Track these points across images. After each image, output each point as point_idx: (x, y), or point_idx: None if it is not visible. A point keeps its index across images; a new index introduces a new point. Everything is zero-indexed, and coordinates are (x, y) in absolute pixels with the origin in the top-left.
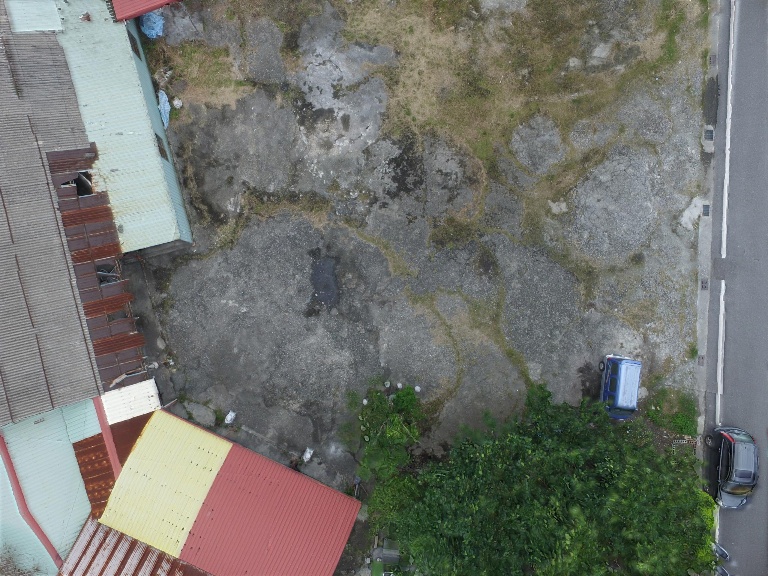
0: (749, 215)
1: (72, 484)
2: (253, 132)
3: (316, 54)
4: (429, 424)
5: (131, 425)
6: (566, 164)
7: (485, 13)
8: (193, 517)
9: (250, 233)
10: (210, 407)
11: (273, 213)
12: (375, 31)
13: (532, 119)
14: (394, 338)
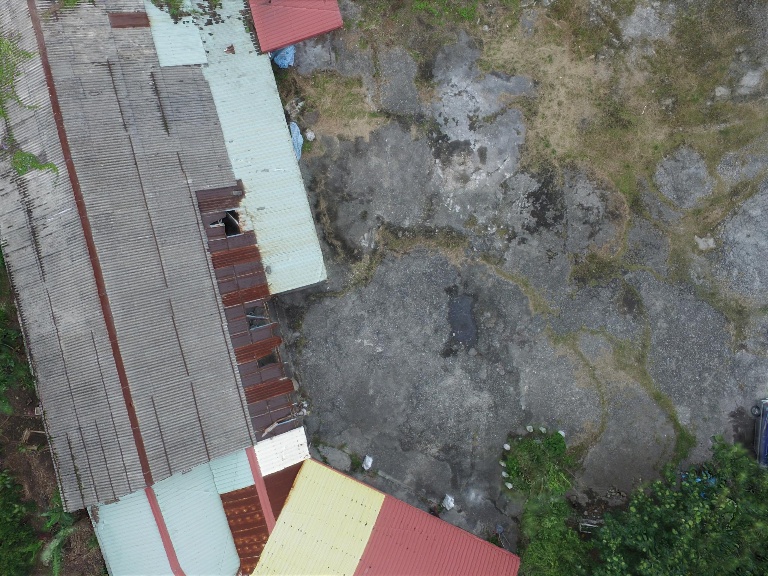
0: None
1: (220, 537)
2: (387, 165)
3: (451, 84)
4: (573, 470)
5: (284, 476)
6: (713, 198)
7: (626, 41)
8: (350, 574)
9: (385, 270)
10: (345, 451)
11: (408, 249)
12: (512, 60)
13: (677, 151)
14: (535, 380)
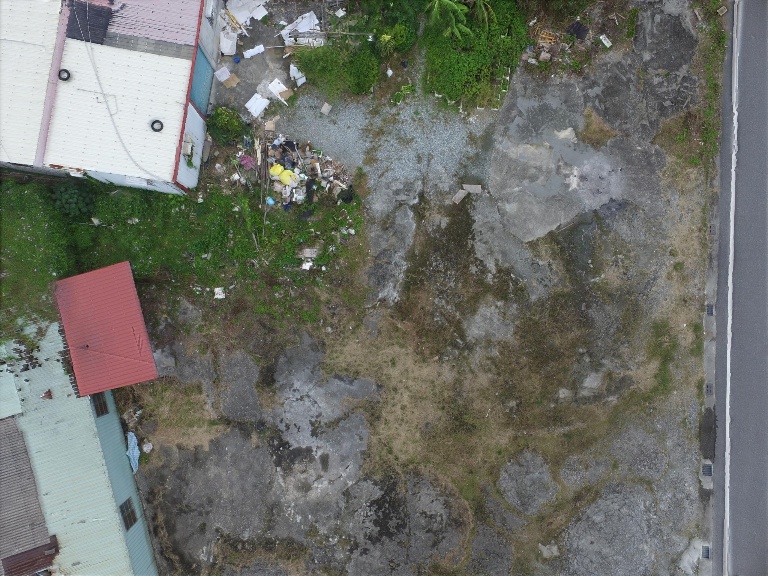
0: (751, 558)
1: None
2: (227, 474)
3: (293, 389)
4: None
5: None
6: (557, 504)
7: (470, 342)
8: None
9: None
10: None
11: (248, 562)
12: (355, 363)
13: (521, 455)
14: None
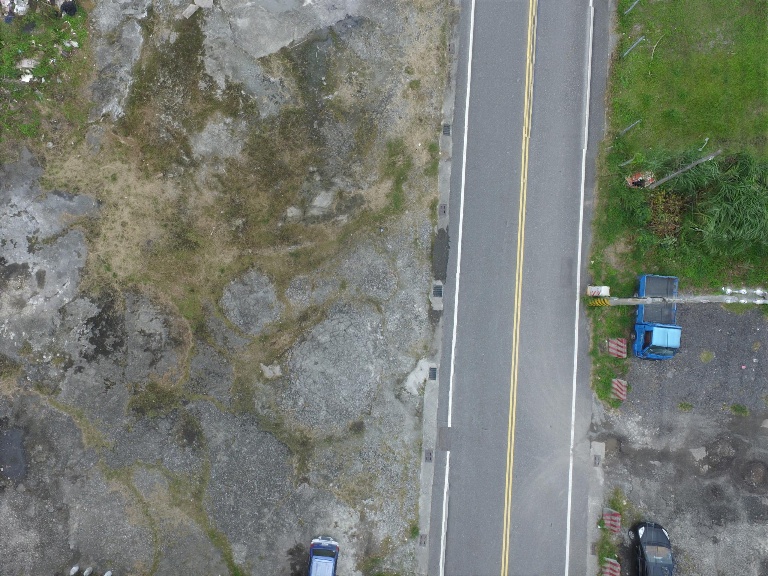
0: (478, 380)
1: None
2: None
3: (11, 204)
4: None
5: None
6: (281, 324)
7: (197, 159)
8: None
9: None
10: None
11: None
12: (76, 179)
13: (245, 274)
14: (86, 517)
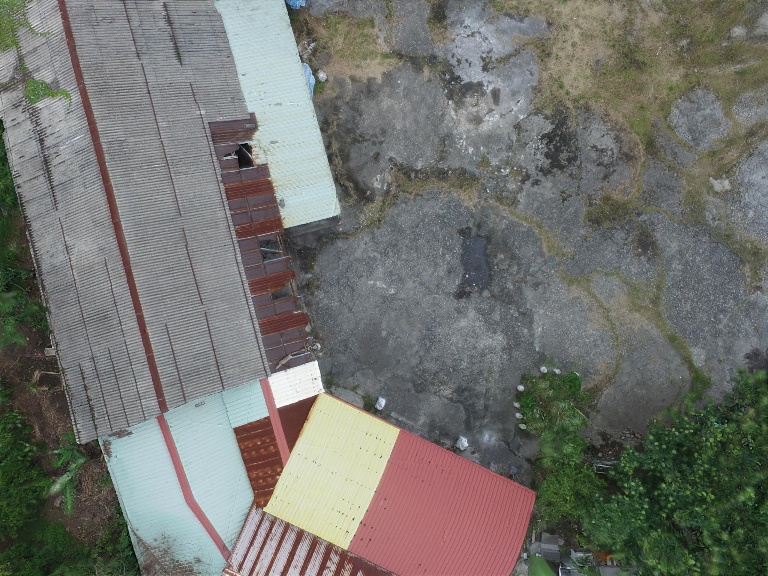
0: None
1: (234, 471)
2: (400, 106)
3: (464, 25)
4: (587, 412)
5: (298, 409)
6: (728, 139)
7: None
8: (365, 506)
9: (397, 211)
10: (358, 393)
11: (421, 190)
12: (526, 1)
13: (691, 92)
14: (549, 321)
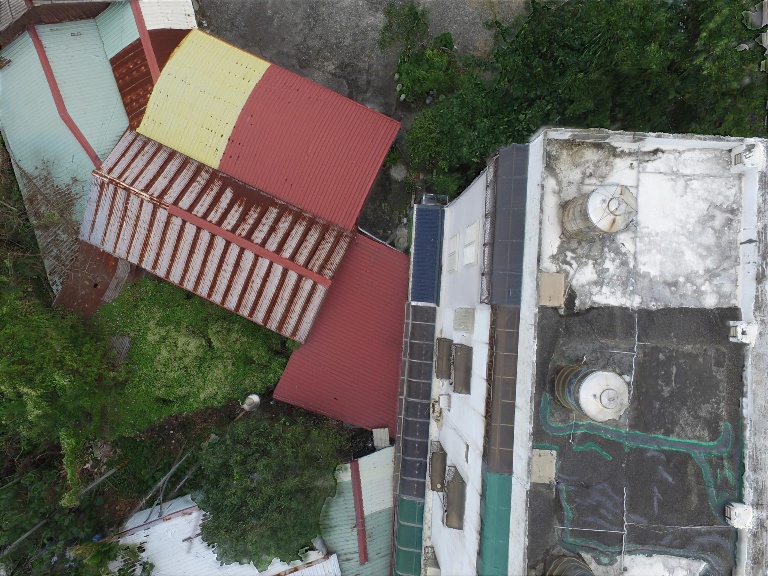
0: None
1: (110, 98)
2: None
3: None
4: None
5: (169, 34)
6: None
7: None
8: (232, 123)
9: None
10: None
11: None
12: None
13: None
14: (430, 0)
